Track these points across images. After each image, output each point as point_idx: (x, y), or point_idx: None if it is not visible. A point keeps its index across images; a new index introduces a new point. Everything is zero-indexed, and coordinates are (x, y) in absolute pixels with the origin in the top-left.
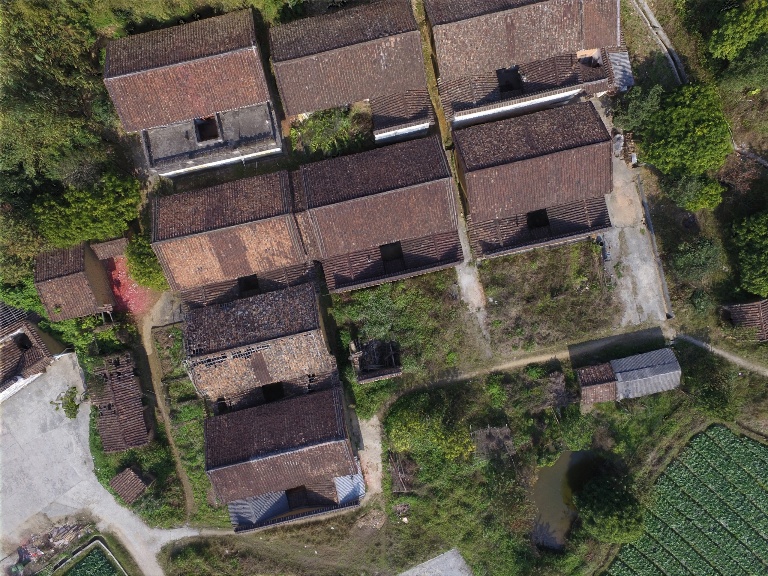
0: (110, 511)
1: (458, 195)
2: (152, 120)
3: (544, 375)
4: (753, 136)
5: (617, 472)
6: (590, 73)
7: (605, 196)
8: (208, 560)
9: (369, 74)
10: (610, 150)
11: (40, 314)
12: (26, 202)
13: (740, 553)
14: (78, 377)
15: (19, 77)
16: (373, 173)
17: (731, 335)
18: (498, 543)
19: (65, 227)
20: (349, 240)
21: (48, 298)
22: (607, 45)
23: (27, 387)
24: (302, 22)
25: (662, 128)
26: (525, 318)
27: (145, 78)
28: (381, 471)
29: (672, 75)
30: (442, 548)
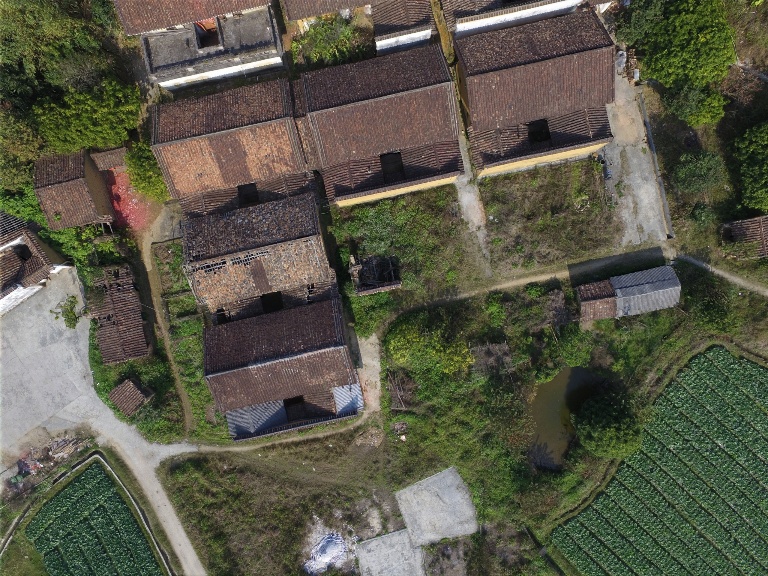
0: (109, 426)
1: (459, 113)
2: (153, 22)
3: (543, 293)
4: (757, 50)
5: (615, 391)
6: None
7: (607, 109)
8: (206, 475)
9: None
10: (612, 56)
11: (40, 224)
12: (26, 103)
13: (737, 474)
14: (78, 292)
15: None
16: (374, 79)
17: (731, 253)
18: (496, 461)
19: (65, 128)
20: (349, 147)
21: (48, 205)
22: None
23: (27, 301)
24: None
25: (665, 38)
26: (525, 237)
27: None
28: (380, 389)
29: None
30: (440, 466)
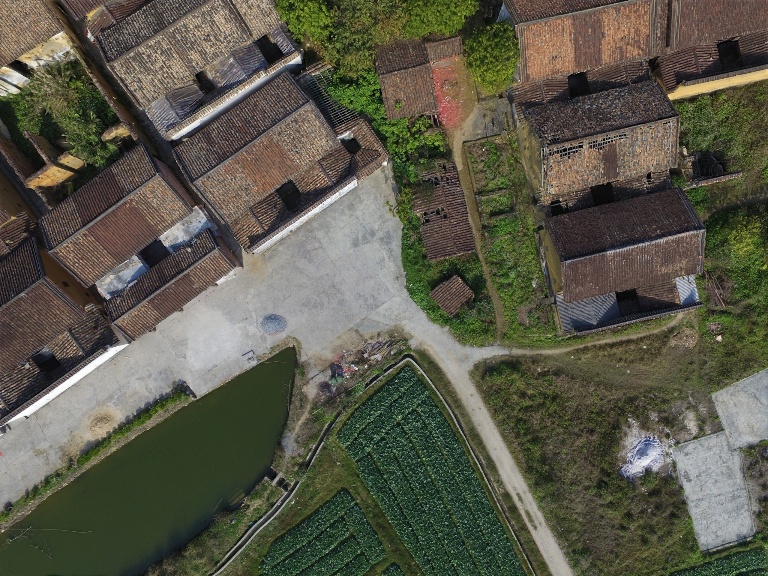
0: (422, 328)
1: None
2: None
3: None
4: None
5: None
6: None
7: None
8: (523, 377)
9: None
10: None
11: (370, 116)
12: None
13: None
14: (390, 191)
15: None
16: None
17: None
18: None
19: (431, 7)
20: (703, 30)
21: (390, 93)
22: None
23: (339, 201)
24: None
25: None
26: None
27: None
28: None
29: None
30: (757, 366)
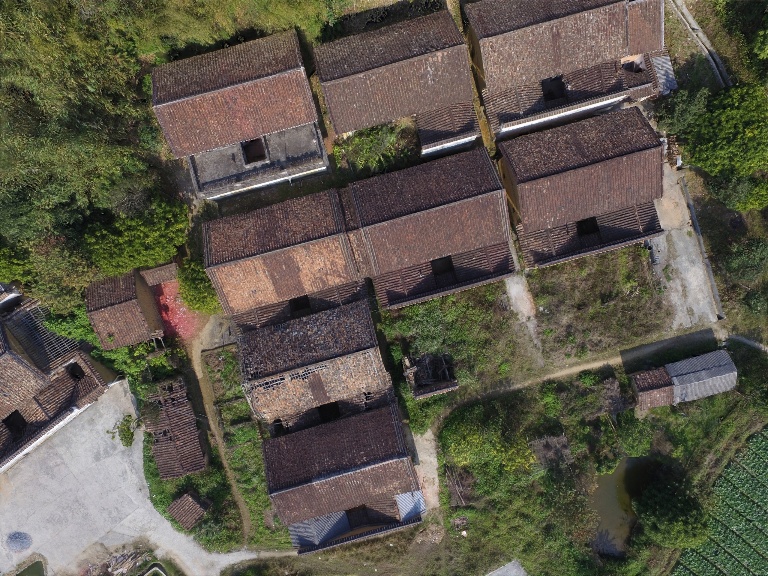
0: (167, 538)
1: None
2: (201, 145)
3: (598, 382)
4: None
5: (675, 476)
6: (634, 78)
7: (654, 200)
8: None
9: (416, 89)
10: (661, 155)
11: (92, 343)
12: (78, 232)
13: None
14: (130, 404)
15: (72, 109)
16: (424, 188)
17: None
18: (559, 553)
19: (119, 256)
20: (402, 256)
21: (101, 327)
22: (651, 50)
23: (79, 416)
24: (346, 40)
25: (709, 130)
26: (576, 325)
27: (194, 103)
28: (438, 485)
29: (714, 76)
30: (503, 560)
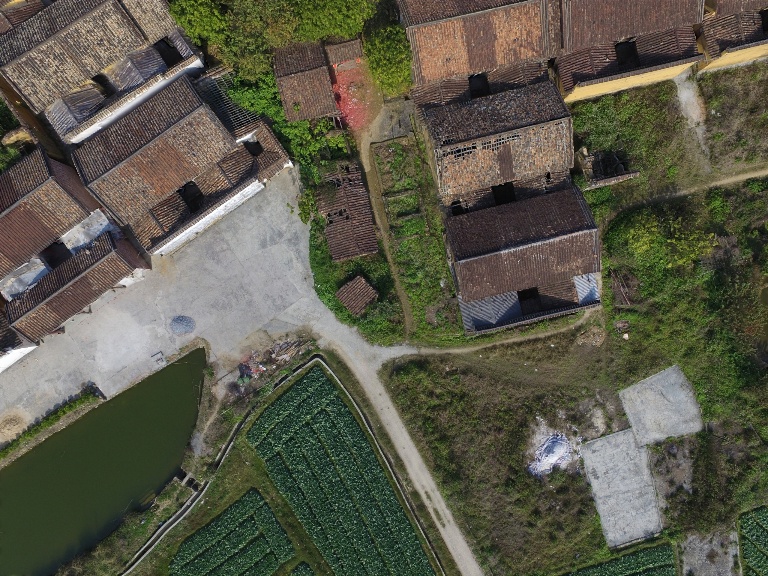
0: (330, 328)
1: None
2: None
3: (767, 187)
4: None
5: None
6: None
7: None
8: (431, 376)
9: None
10: None
11: (272, 118)
12: None
13: None
14: (298, 193)
15: None
16: None
17: None
18: (720, 358)
19: (321, 10)
20: (596, 31)
21: (288, 95)
22: None
23: (247, 202)
24: None
25: None
26: (746, 131)
27: None
28: (601, 287)
29: None
30: (664, 364)
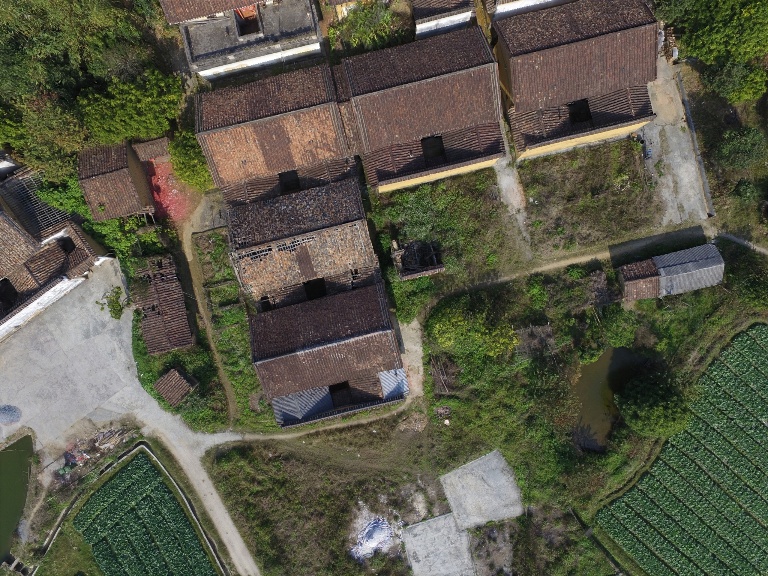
0: (154, 416)
1: None
2: (194, 10)
3: (585, 275)
4: None
5: (659, 371)
6: None
7: (648, 88)
8: (252, 463)
9: None
10: (656, 33)
11: (83, 216)
12: (70, 94)
13: None
14: (120, 283)
15: None
16: (416, 62)
17: None
18: (540, 444)
19: (110, 118)
20: (392, 131)
21: (92, 196)
22: None
23: (70, 294)
24: None
25: (706, 15)
26: (565, 218)
27: None
28: (422, 374)
29: None
30: (484, 449)
